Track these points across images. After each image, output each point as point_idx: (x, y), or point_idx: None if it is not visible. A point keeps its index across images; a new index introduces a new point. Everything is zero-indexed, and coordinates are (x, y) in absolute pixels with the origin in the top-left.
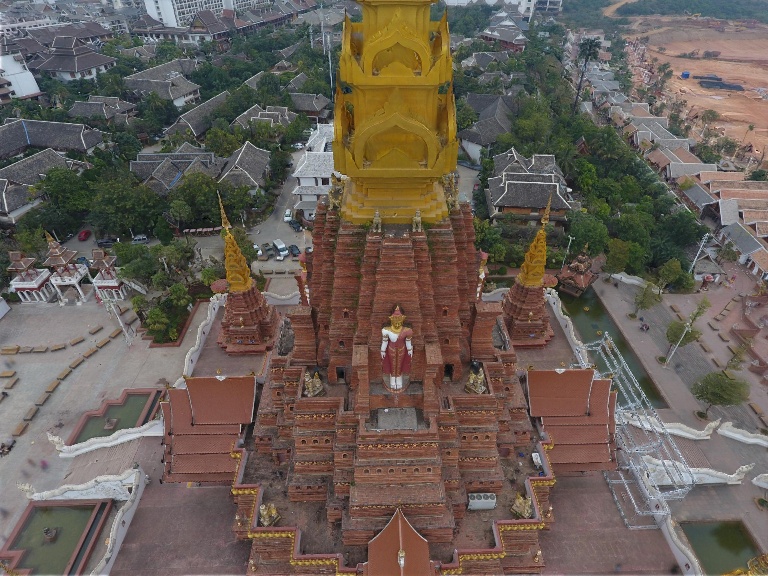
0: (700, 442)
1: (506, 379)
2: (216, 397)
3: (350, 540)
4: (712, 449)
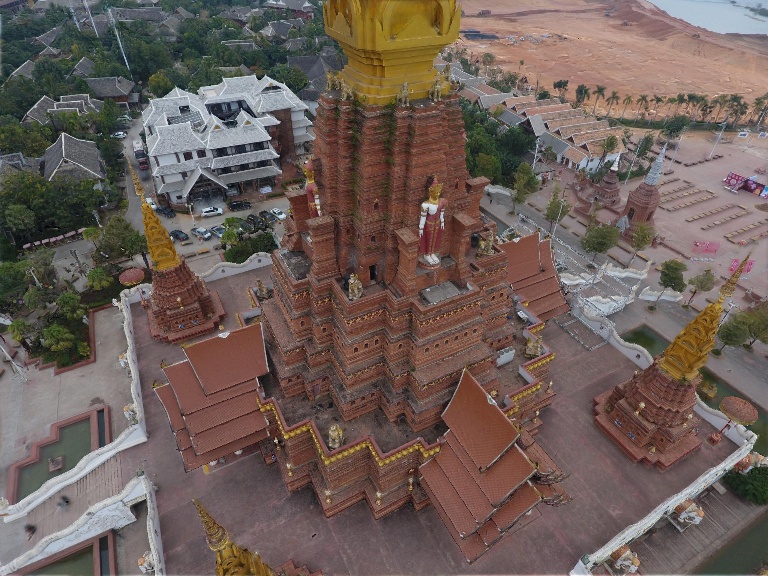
0: (597, 284)
1: None
2: (223, 358)
3: (421, 424)
4: None
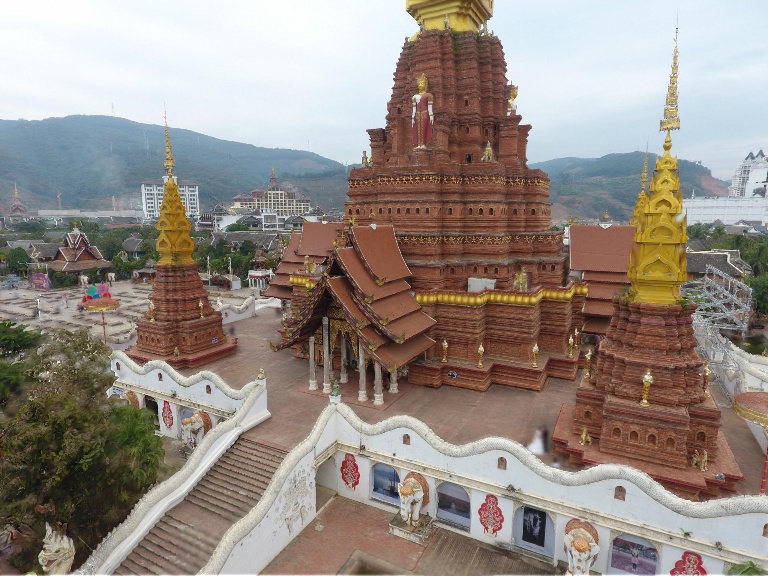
0: None
1: (532, 200)
2: (317, 238)
3: None
4: None
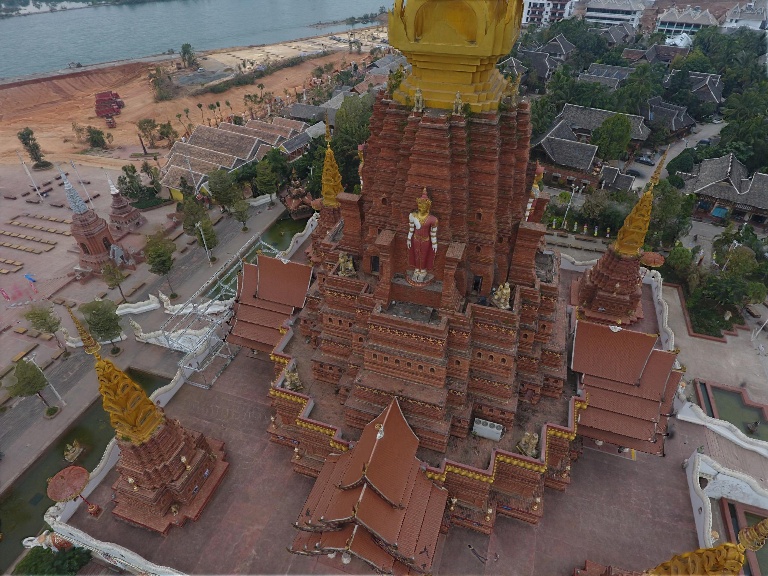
0: None
1: None
2: None
3: None
4: (151, 330)
